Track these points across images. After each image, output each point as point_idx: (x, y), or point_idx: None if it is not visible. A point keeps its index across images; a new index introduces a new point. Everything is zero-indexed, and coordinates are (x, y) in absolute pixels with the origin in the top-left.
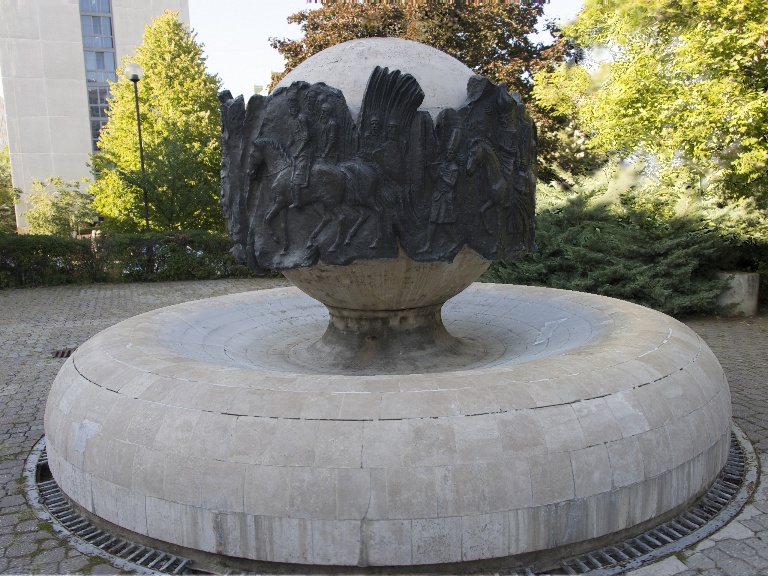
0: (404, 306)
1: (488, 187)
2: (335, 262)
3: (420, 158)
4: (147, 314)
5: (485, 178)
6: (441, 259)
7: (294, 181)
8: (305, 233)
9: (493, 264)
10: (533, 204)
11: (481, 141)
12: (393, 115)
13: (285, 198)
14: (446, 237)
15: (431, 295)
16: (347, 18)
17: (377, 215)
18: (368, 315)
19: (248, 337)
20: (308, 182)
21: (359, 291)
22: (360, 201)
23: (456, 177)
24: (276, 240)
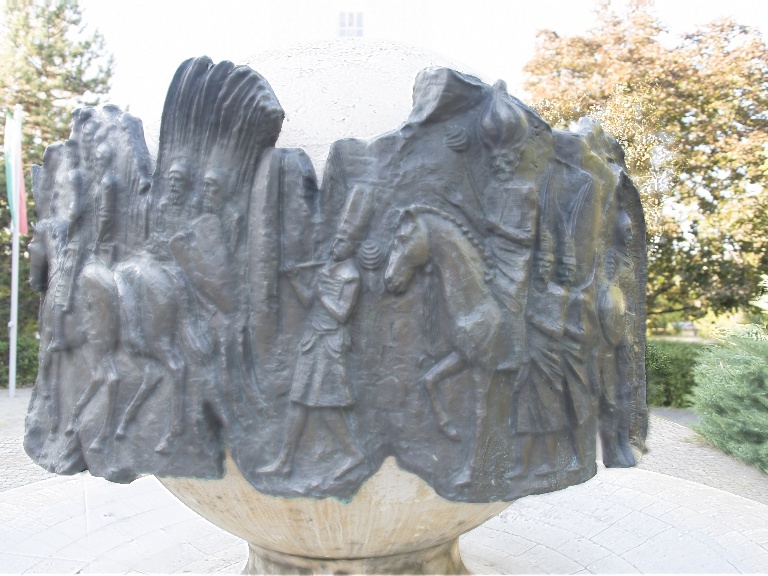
0: (329, 554)
1: (447, 321)
2: (100, 473)
3: (263, 252)
4: (49, 481)
5: (439, 300)
6: (312, 494)
7: (54, 298)
8: (70, 403)
9: (707, 406)
10: (622, 356)
11: (427, 212)
12: (214, 158)
13: (52, 330)
14: (330, 439)
15: (376, 542)
16: (536, 101)
17: (171, 379)
18: (275, 557)
19: (170, 537)
20: (69, 301)
21: (221, 519)
22: (140, 346)
23: (350, 297)
24: (47, 410)
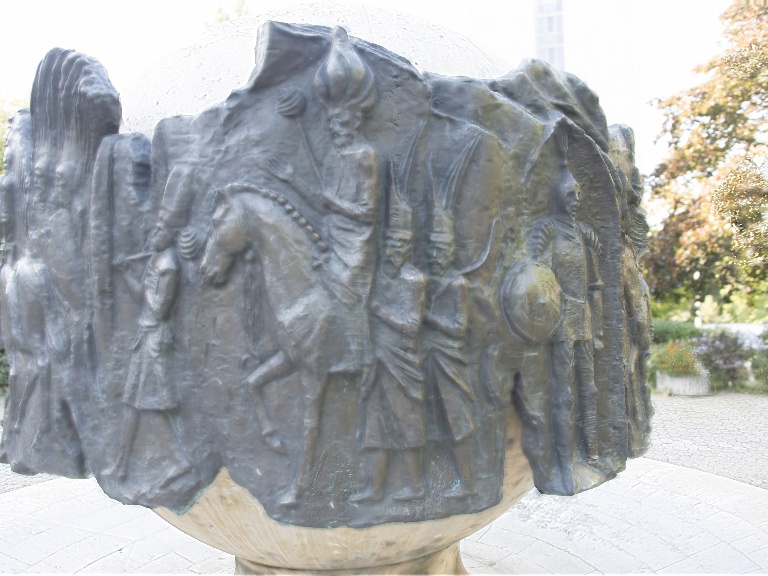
0: None
1: (271, 316)
2: None
3: (93, 245)
4: None
5: (263, 291)
6: (140, 502)
7: None
8: None
9: None
10: (560, 354)
11: (246, 190)
12: (65, 151)
13: None
14: (159, 445)
15: (296, 555)
16: (738, 47)
17: None
18: None
19: None
20: None
21: None
22: (21, 343)
23: (164, 290)
24: None
